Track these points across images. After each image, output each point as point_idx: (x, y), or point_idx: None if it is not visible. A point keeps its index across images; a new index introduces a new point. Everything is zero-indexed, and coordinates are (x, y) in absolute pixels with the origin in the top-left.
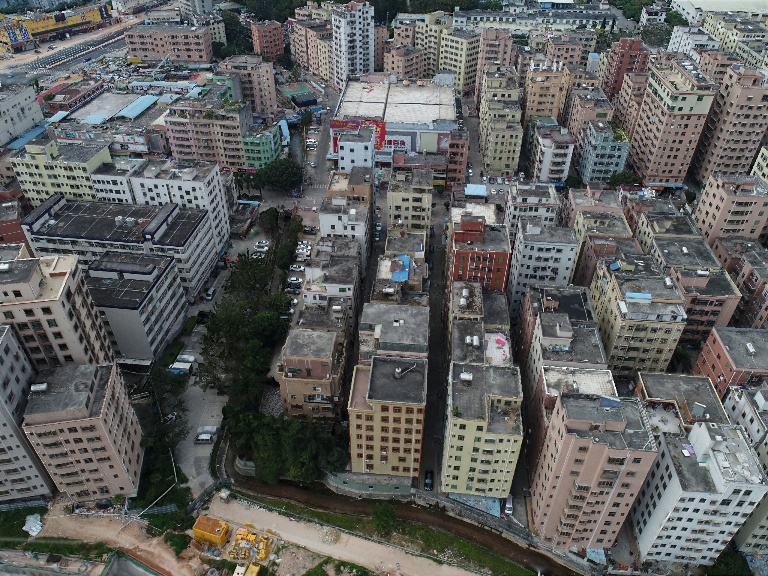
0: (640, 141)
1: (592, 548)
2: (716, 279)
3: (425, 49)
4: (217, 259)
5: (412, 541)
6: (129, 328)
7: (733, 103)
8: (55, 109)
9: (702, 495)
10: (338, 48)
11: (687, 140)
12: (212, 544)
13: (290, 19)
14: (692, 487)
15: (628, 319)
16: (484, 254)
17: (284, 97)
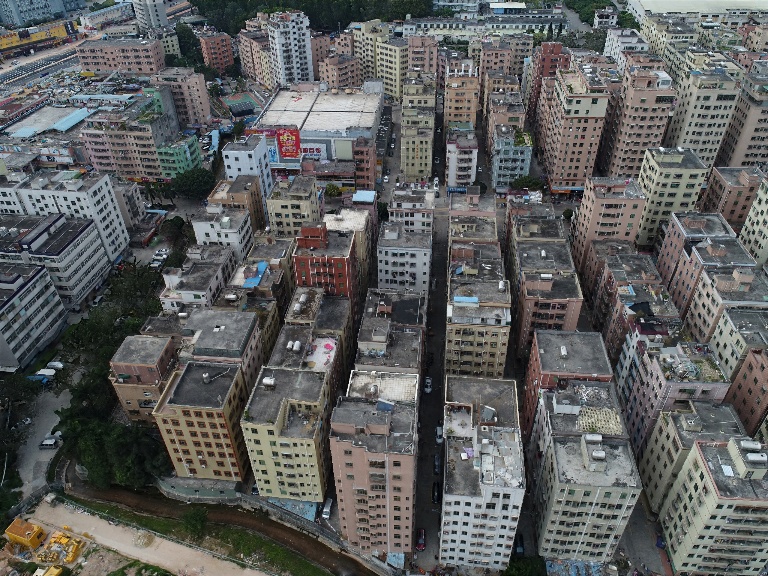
0: (549, 145)
1: (393, 552)
2: (565, 282)
3: (363, 57)
4: (110, 268)
5: (222, 545)
6: None
7: (628, 105)
8: None
9: (465, 498)
10: (275, 58)
11: (588, 143)
12: (24, 547)
13: (243, 30)
14: (458, 490)
15: (454, 323)
16: (322, 260)
17: None
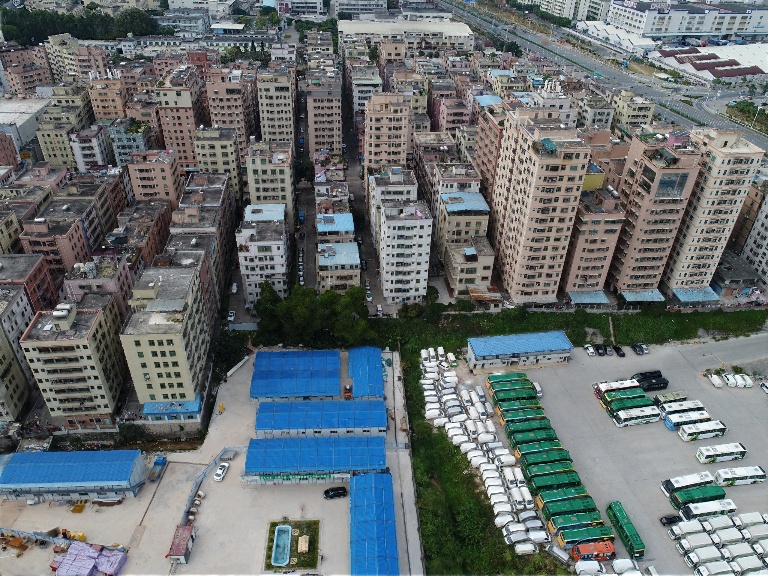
0: None
1: None
2: (65, 226)
3: (58, 68)
4: None
5: None
6: None
7: None
8: None
9: None
10: None
11: (186, 130)
12: None
13: None
14: None
15: None
16: None
17: None
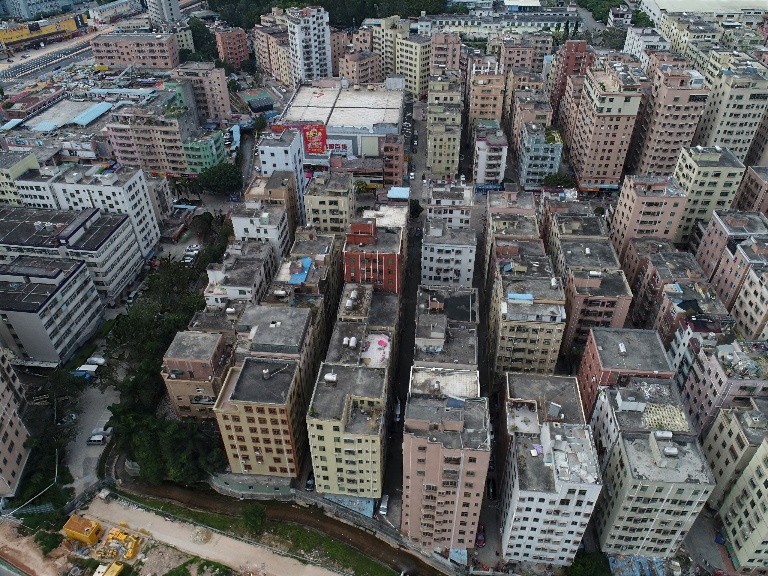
0: (577, 143)
1: (455, 548)
2: (612, 280)
3: (382, 54)
4: (143, 263)
5: (281, 541)
6: (32, 331)
7: (661, 104)
8: (14, 117)
9: (540, 495)
10: (294, 54)
11: (618, 141)
12: (82, 543)
13: (257, 26)
14: (532, 487)
15: (508, 320)
16: (373, 256)
17: (243, 103)
